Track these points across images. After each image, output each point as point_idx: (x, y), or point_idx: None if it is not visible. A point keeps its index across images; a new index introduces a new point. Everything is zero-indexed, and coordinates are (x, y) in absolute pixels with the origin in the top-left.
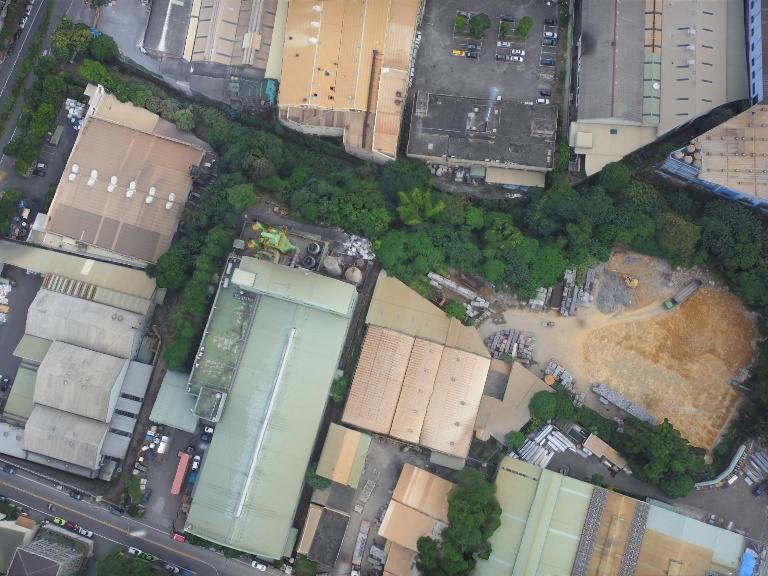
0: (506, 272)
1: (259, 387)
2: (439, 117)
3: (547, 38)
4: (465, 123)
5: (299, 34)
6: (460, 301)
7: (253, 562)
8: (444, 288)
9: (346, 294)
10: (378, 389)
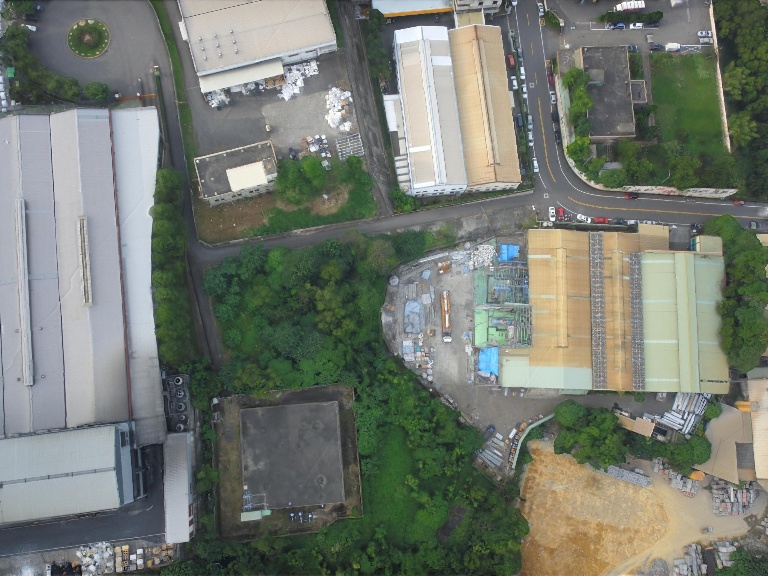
0: None
1: None
2: None
3: None
4: None
5: None
6: None
7: None
8: None
9: None
10: None
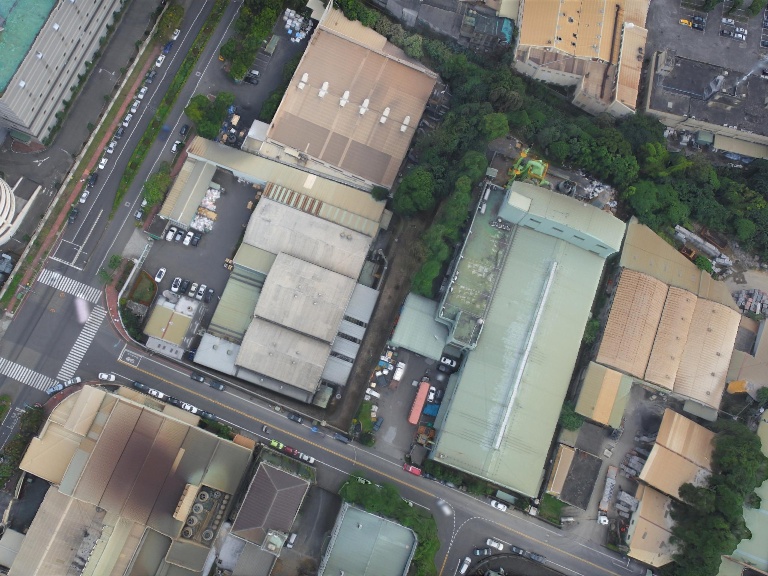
0: (756, 232)
1: (517, 318)
2: (678, 78)
3: (767, 22)
4: (703, 87)
5: None
6: (705, 256)
7: (493, 501)
8: (687, 242)
9: (619, 231)
10: (636, 332)
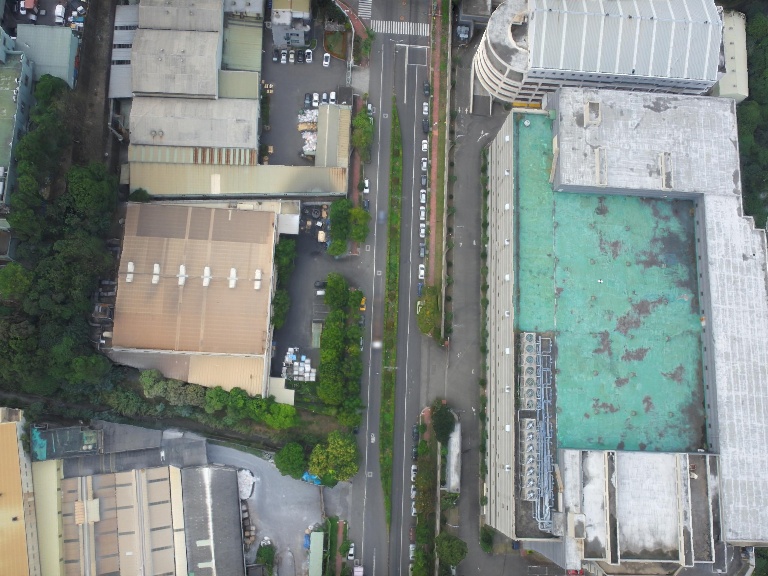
0: None
1: None
2: None
3: None
4: None
5: (3, 527)
6: None
7: None
8: None
9: None
10: None
